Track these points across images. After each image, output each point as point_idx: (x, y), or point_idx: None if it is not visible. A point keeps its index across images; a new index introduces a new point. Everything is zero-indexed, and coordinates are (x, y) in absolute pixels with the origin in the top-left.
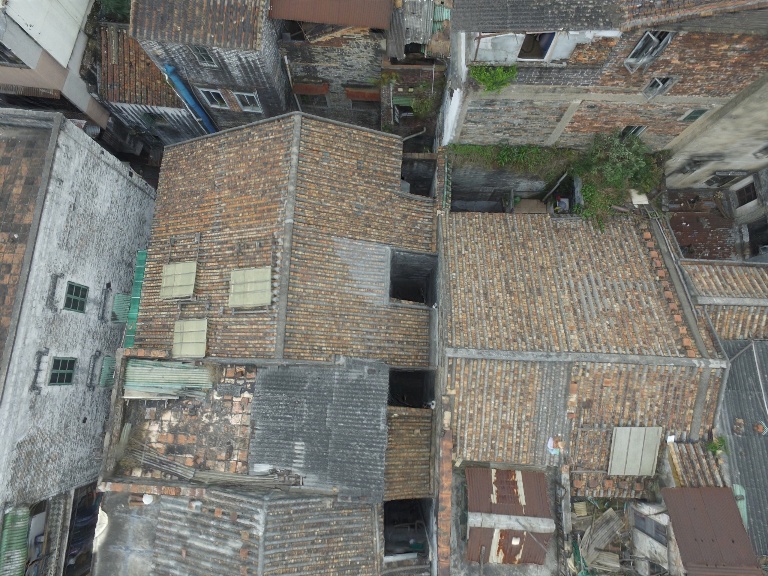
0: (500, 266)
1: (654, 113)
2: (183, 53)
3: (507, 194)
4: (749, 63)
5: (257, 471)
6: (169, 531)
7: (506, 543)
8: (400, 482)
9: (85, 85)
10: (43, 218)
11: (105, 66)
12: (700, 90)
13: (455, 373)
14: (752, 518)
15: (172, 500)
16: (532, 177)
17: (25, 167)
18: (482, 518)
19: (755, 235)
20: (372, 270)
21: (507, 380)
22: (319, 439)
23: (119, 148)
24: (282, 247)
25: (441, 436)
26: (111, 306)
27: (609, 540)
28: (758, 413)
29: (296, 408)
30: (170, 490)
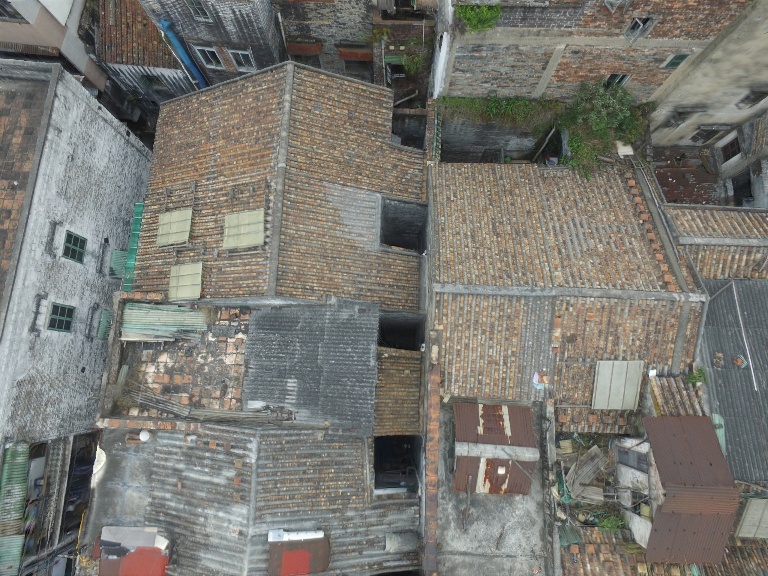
0: (488, 211)
1: (637, 59)
2: (178, 7)
3: (497, 153)
4: (726, 0)
5: (251, 407)
6: (165, 466)
7: (492, 472)
8: (390, 419)
9: (83, 45)
10: (42, 164)
11: (103, 27)
12: (680, 32)
13: (443, 308)
14: (730, 445)
15: (168, 436)
16: (521, 134)
17: (24, 118)
18: (469, 447)
19: (740, 190)
20: (363, 216)
21: (493, 315)
22: (311, 376)
23: (117, 113)
24: (275, 190)
25: (429, 370)
26: (109, 261)
27: (594, 476)
28: (737, 348)
29: (289, 347)
30: (166, 425)
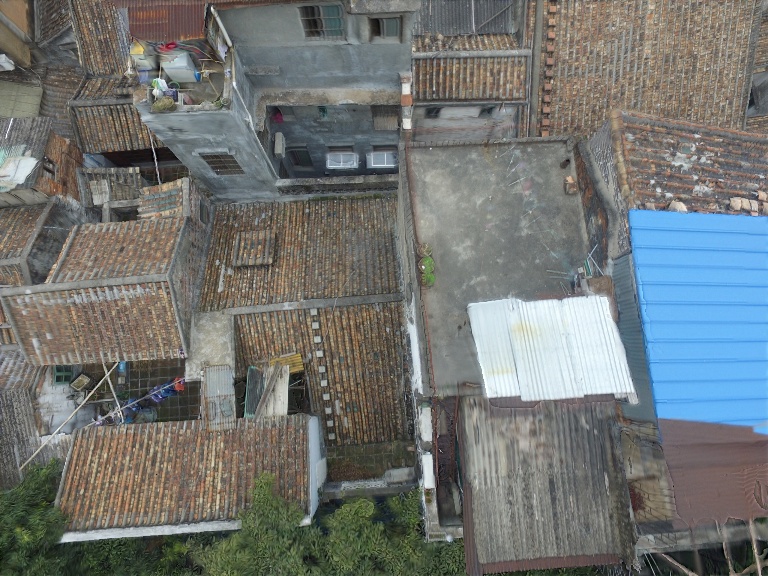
0: None
1: None
2: None
3: None
4: None
5: None
6: None
7: None
8: None
9: None
10: None
11: None
12: None
13: None
14: None
15: None
16: None
17: None
18: None
19: None
20: None
21: None
22: None
23: None
24: None
25: None
26: None
27: None
28: None
29: None
30: None
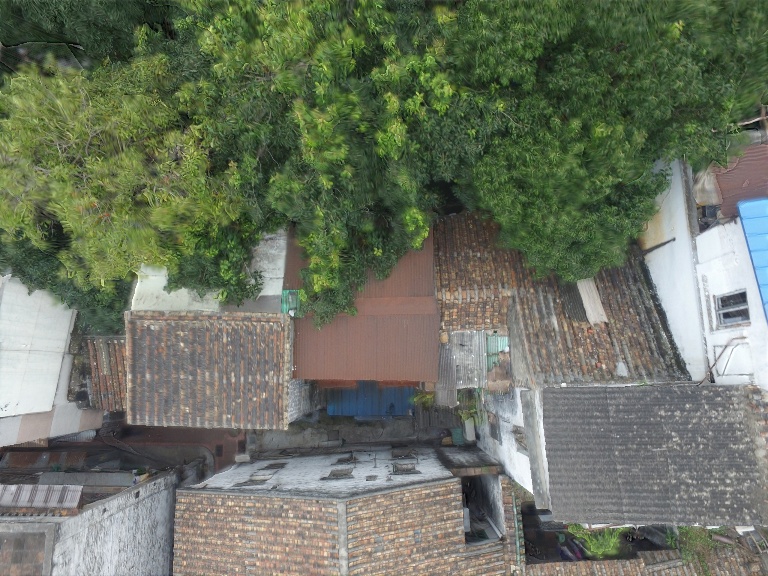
0: None
1: None
2: None
3: None
4: None
5: None
6: None
7: None
8: None
9: (75, 404)
10: None
11: (96, 377)
12: None
13: None
14: None
15: None
16: None
17: None
18: None
19: None
20: None
21: None
22: None
23: None
24: None
25: None
26: None
27: None
28: None
29: None
30: None
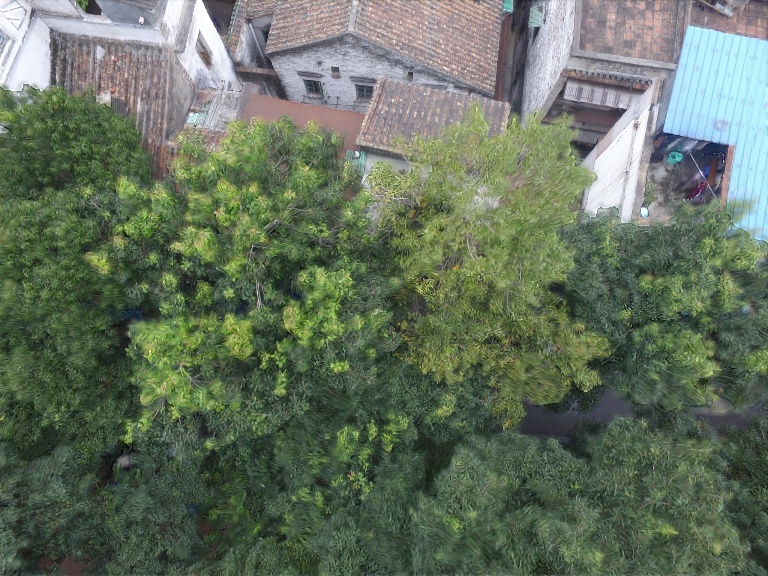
0: None
1: None
2: None
3: None
4: None
5: None
6: None
7: None
8: None
9: None
10: None
11: None
12: None
13: None
14: None
15: None
16: None
17: (608, 37)
18: None
19: None
20: None
21: None
22: None
23: None
24: None
25: None
26: None
27: None
28: None
29: None
30: None
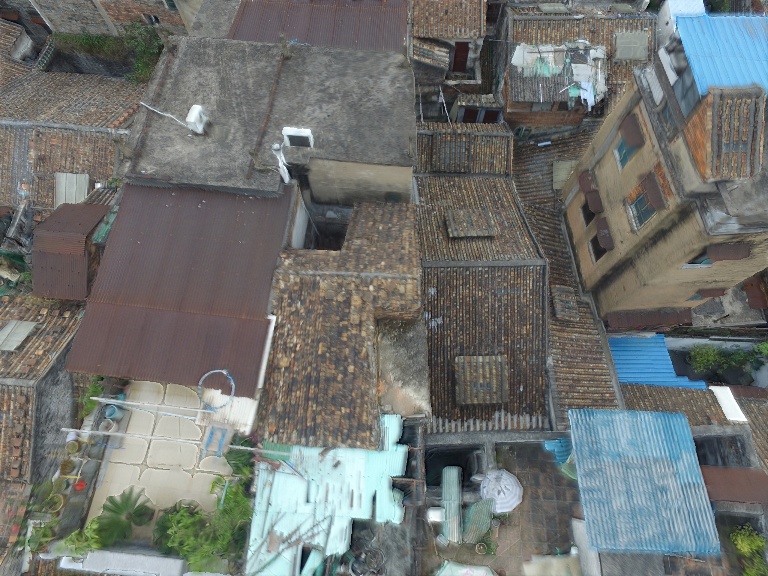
0: None
1: None
2: None
3: None
4: None
5: None
6: None
7: None
8: None
9: None
10: None
11: None
12: None
13: None
14: None
15: None
16: None
17: None
18: None
19: None
20: None
21: None
22: None
23: None
24: None
25: None
26: None
27: None
28: None
29: None
30: None
